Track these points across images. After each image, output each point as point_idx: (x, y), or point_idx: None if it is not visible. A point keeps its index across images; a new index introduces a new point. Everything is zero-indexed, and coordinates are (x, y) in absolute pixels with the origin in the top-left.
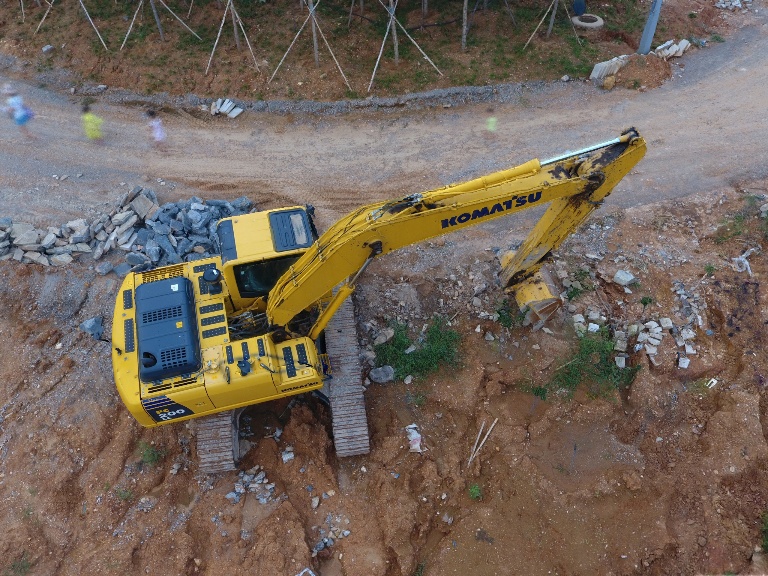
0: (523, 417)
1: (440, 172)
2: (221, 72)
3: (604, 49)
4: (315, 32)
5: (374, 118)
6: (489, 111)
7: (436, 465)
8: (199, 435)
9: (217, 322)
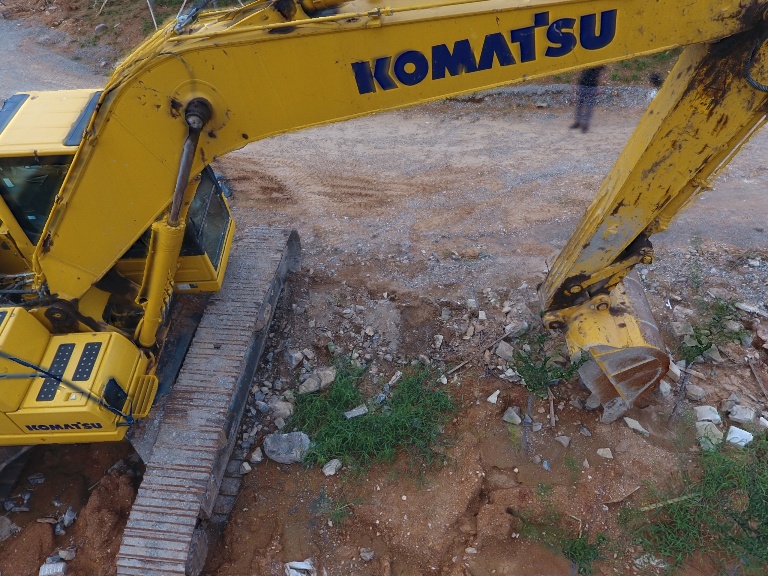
0: None
1: (505, 170)
2: None
3: None
4: None
5: (436, 111)
6: (601, 114)
7: None
8: None
9: None
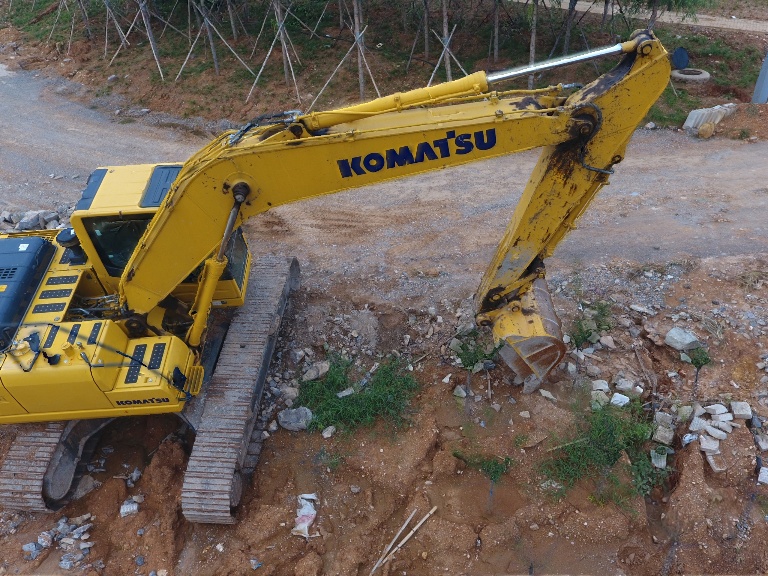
0: (479, 514)
1: (463, 203)
2: (262, 102)
3: (707, 101)
4: (360, 62)
5: None
6: None
7: (320, 561)
8: (11, 451)
9: (59, 296)
